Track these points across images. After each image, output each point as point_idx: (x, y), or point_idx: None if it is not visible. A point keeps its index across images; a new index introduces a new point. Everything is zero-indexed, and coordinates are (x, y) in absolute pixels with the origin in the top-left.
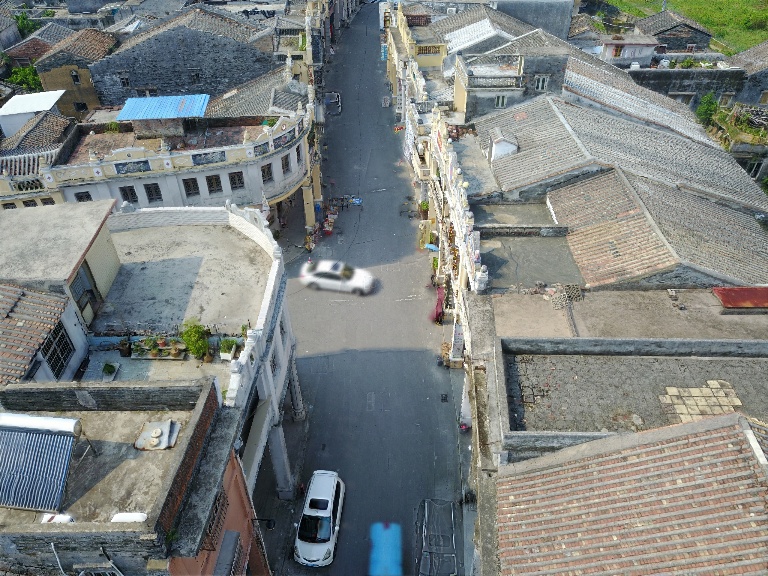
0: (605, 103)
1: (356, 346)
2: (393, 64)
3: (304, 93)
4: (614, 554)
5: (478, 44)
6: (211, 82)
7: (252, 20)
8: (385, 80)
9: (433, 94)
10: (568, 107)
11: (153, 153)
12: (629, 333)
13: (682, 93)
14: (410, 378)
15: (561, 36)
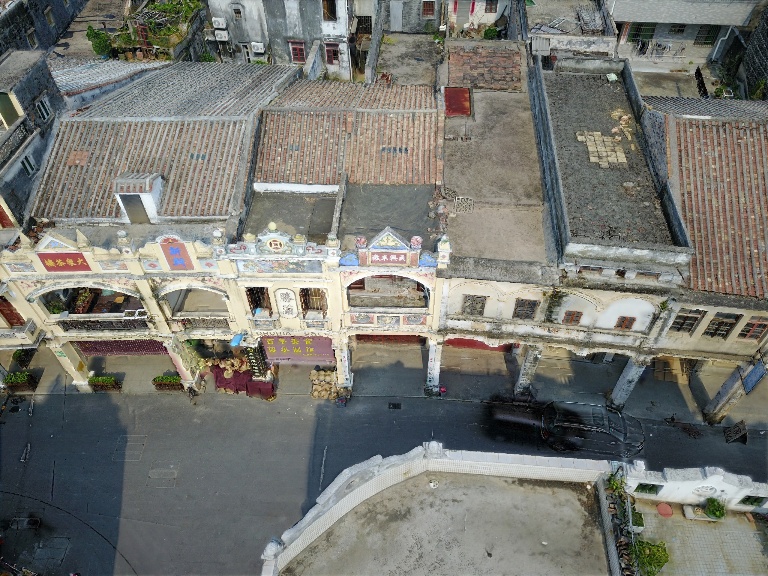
0: (99, 84)
1: (297, 502)
2: None
3: None
4: (766, 220)
5: None
6: None
7: None
8: None
9: None
10: (92, 112)
11: None
12: (503, 174)
13: (3, 57)
14: (362, 439)
15: None
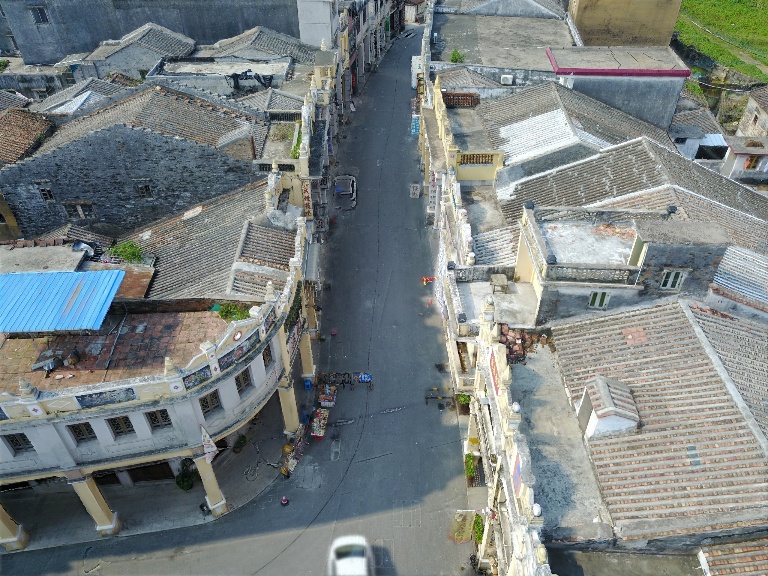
0: None
1: None
2: (426, 146)
3: (292, 227)
4: None
5: (550, 155)
6: (166, 196)
7: (232, 101)
8: (416, 153)
9: (482, 237)
10: (718, 322)
11: (8, 396)
12: None
13: None
14: None
15: (660, 125)
